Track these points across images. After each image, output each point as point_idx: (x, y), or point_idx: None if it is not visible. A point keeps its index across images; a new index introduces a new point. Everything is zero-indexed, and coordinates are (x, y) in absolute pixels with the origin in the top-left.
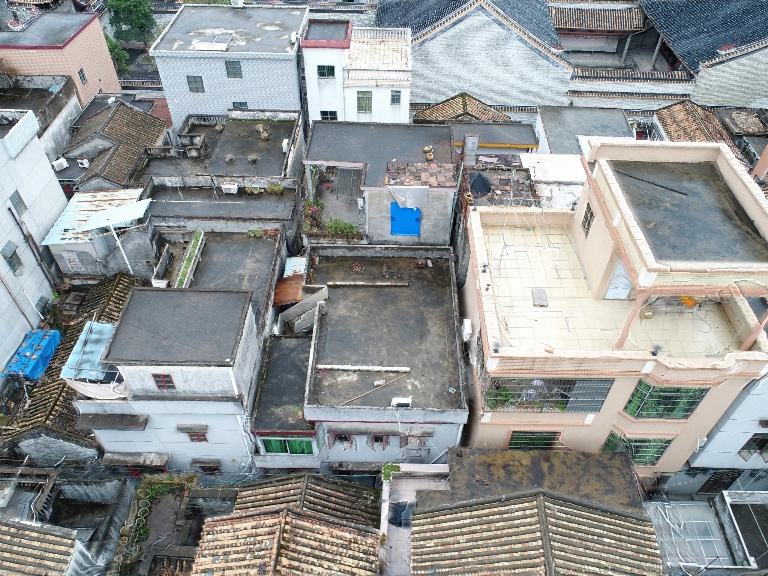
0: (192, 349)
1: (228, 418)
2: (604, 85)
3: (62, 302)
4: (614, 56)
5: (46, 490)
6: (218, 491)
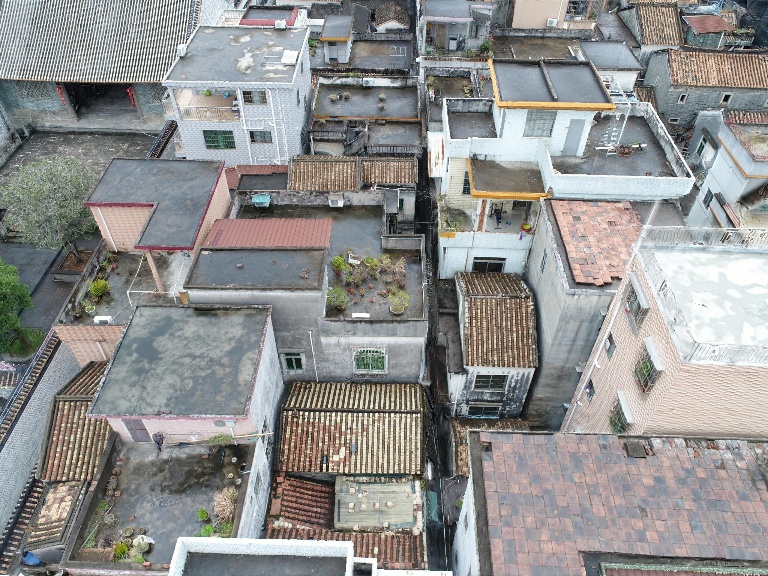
0: (623, 50)
1: None
2: (241, 4)
3: None
4: None
5: None
6: None
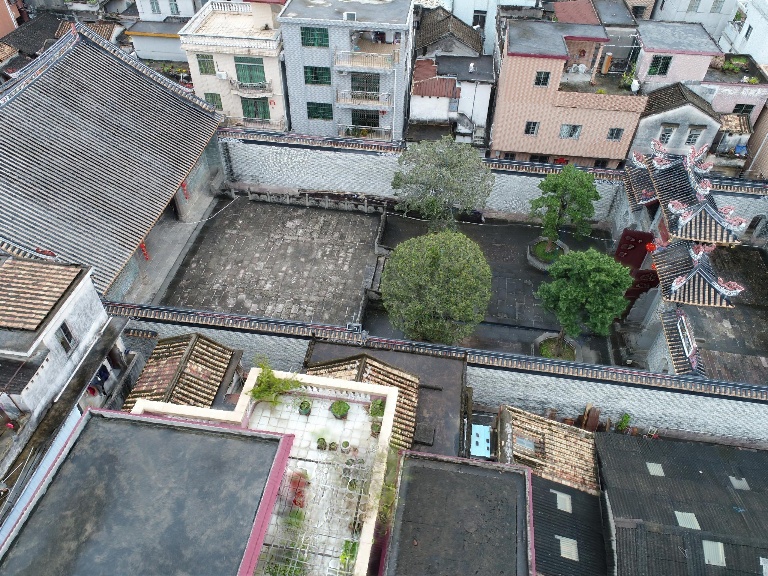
0: None
1: None
2: None
3: None
4: None
5: None
6: None
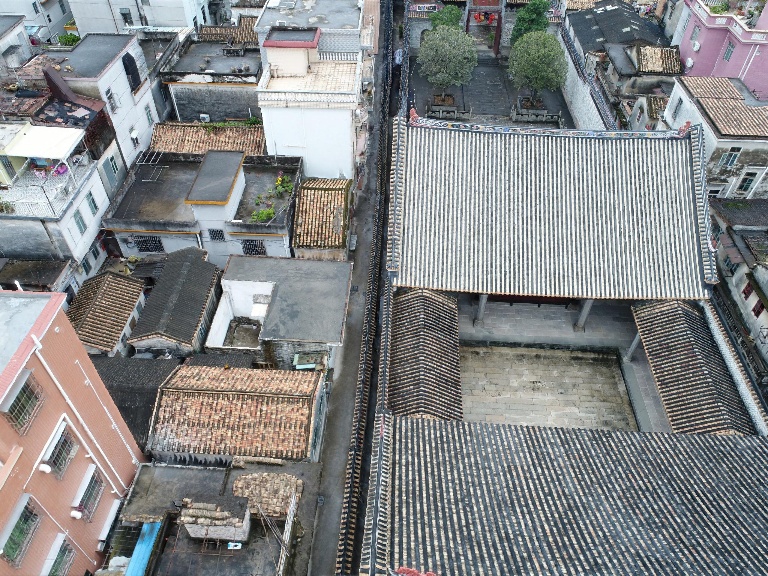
0: None
1: None
2: None
3: None
4: None
5: None
6: None
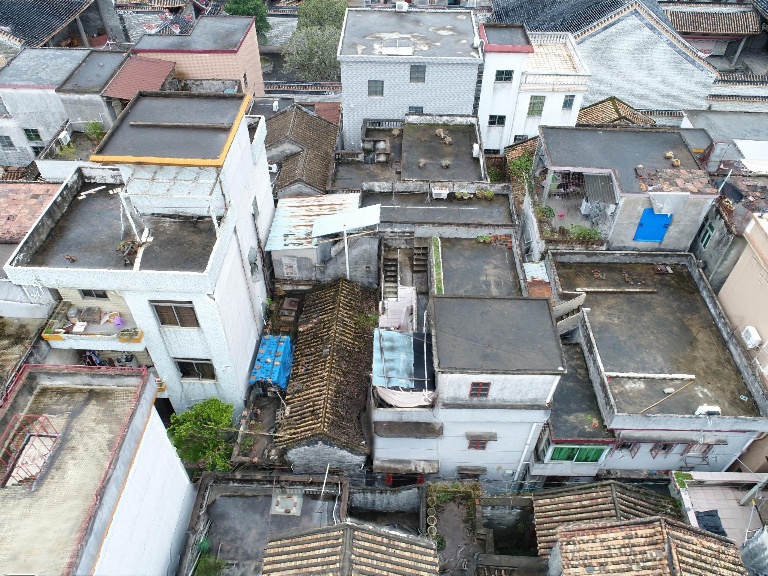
0: (520, 357)
1: (523, 426)
2: (746, 89)
3: (278, 308)
4: (722, 59)
5: (345, 498)
6: (509, 499)
